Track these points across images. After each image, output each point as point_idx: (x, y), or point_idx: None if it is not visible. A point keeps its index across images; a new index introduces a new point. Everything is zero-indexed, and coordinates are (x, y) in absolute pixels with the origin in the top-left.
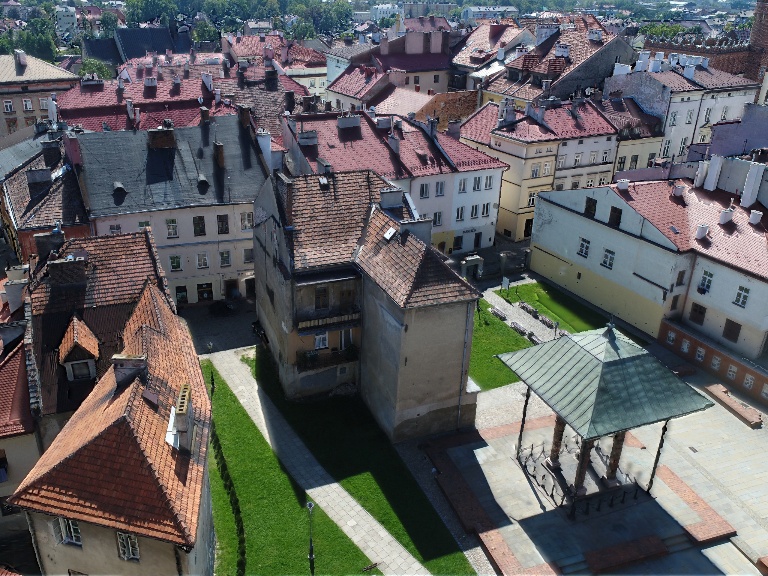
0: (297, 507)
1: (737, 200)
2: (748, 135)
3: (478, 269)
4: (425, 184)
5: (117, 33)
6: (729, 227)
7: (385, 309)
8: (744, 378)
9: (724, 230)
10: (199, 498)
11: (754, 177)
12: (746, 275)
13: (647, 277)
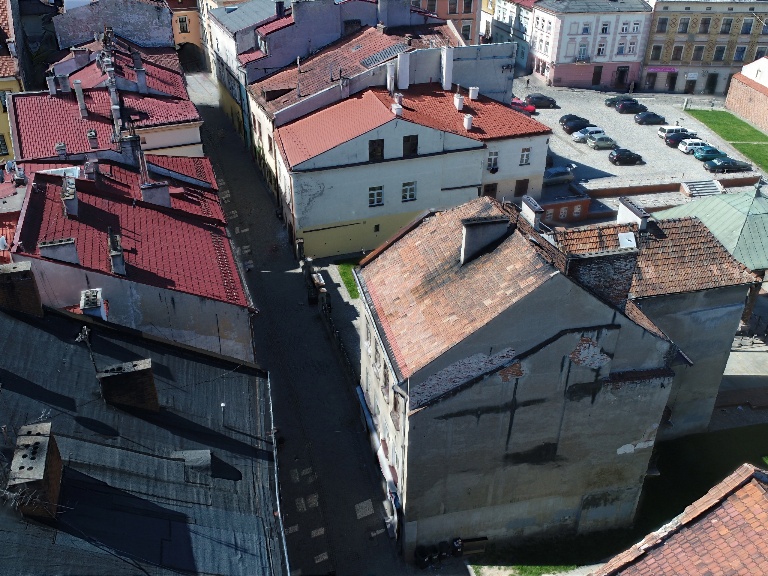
0: None
1: (434, 87)
2: (307, 34)
3: None
4: None
5: None
6: (468, 110)
7: (702, 311)
8: None
9: None
10: None
11: (452, 60)
12: (530, 137)
13: (457, 185)
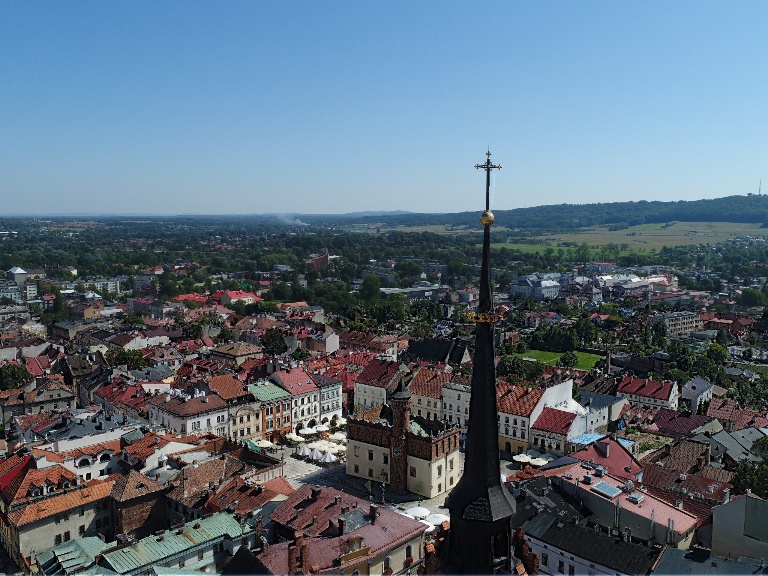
0: None
1: None
2: None
3: None
4: None
5: (424, 340)
6: None
7: None
8: None
9: None
10: None
11: None
12: None
13: None
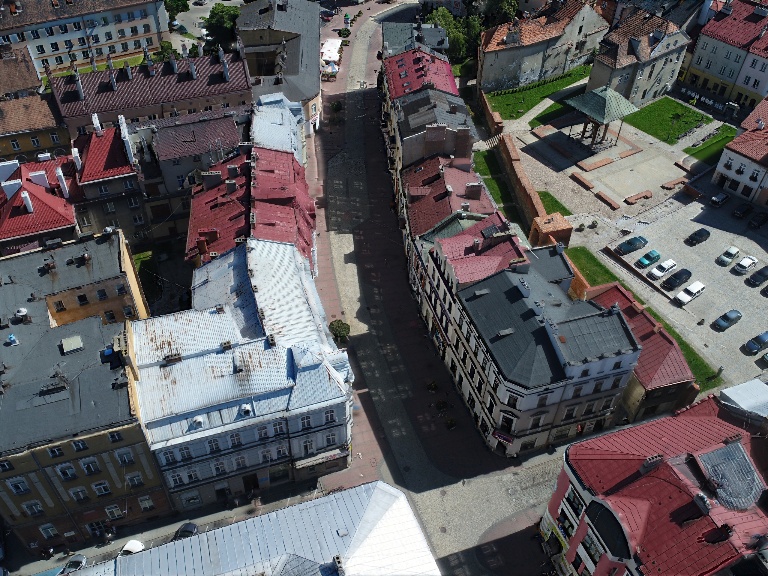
0: (539, 97)
1: None
2: None
3: (734, 112)
4: (757, 60)
5: None
6: None
7: None
8: None
9: None
10: (496, 50)
11: None
12: None
13: None
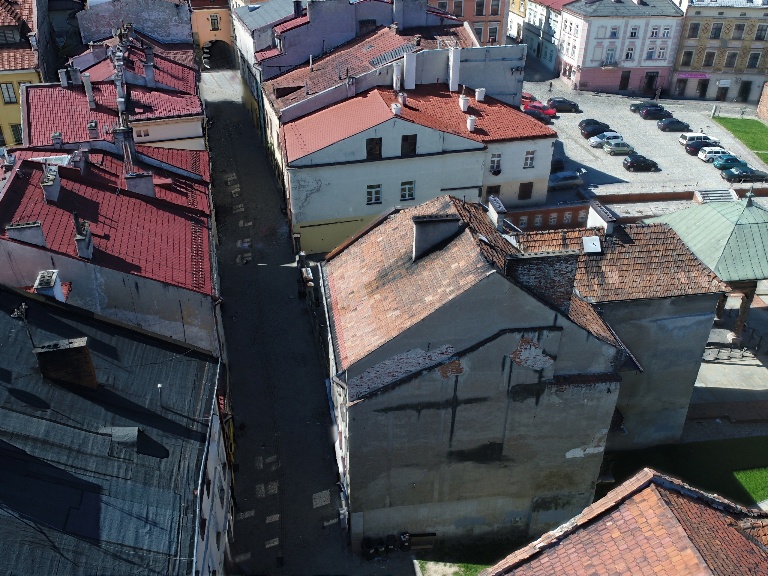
0: None
1: (441, 88)
2: (322, 33)
3: None
4: None
5: None
6: (473, 111)
7: (668, 319)
8: (564, 217)
9: (474, 115)
10: None
11: (459, 61)
12: None
13: (456, 186)
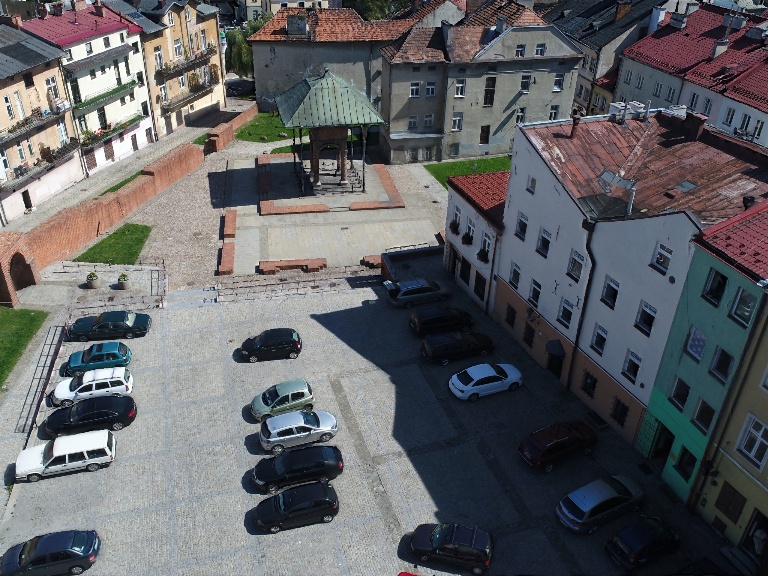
0: None
1: None
2: None
3: None
4: None
5: None
6: None
7: None
8: None
9: None
10: (268, 40)
11: None
12: None
13: None
